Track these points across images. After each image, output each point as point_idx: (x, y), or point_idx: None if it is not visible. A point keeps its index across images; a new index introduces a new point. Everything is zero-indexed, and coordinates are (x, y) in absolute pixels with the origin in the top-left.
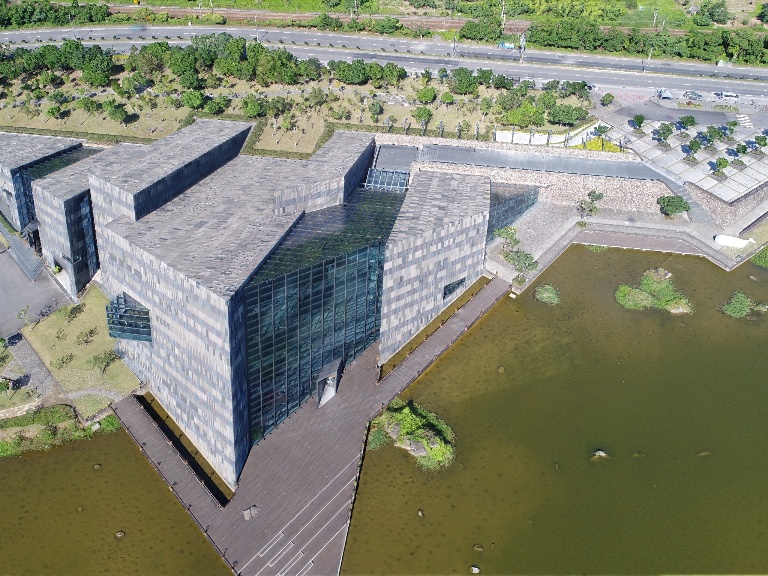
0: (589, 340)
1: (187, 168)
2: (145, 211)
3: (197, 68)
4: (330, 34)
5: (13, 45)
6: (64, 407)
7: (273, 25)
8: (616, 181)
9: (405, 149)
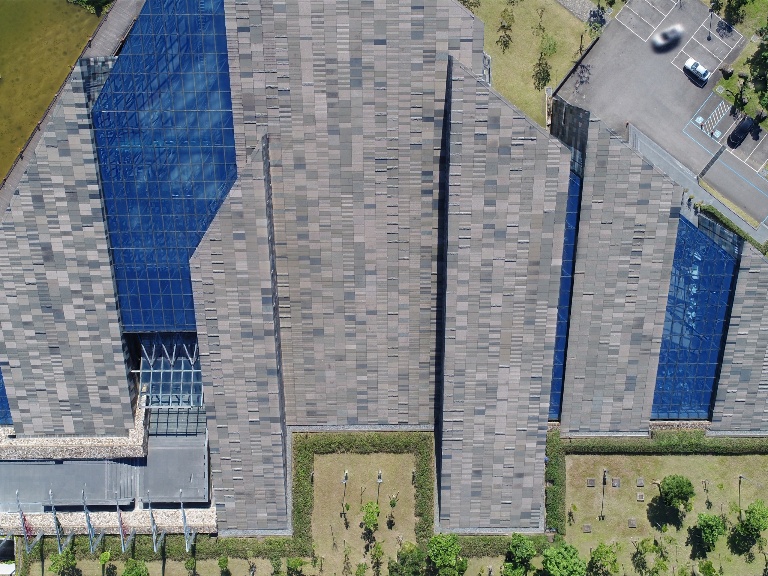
0: None
1: None
2: None
3: None
4: None
5: None
6: None
7: None
8: None
9: (165, 498)
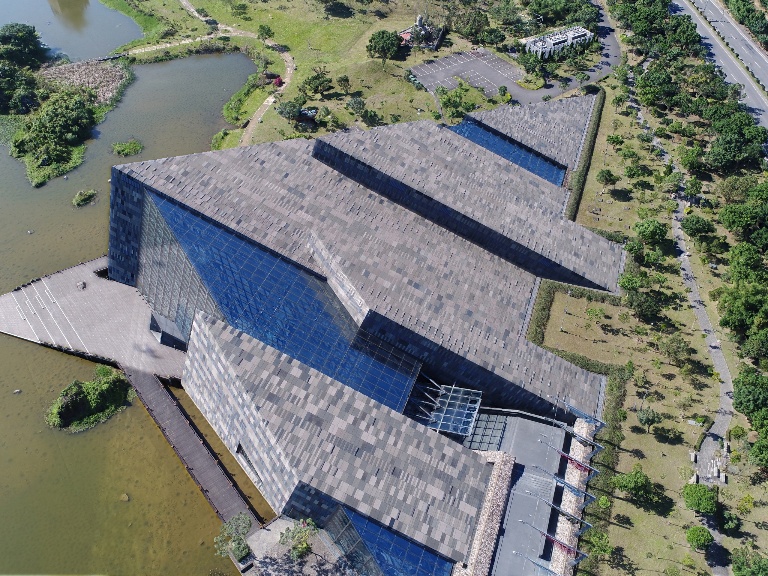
0: None
1: (422, 196)
2: (330, 162)
3: None
4: None
5: None
6: None
7: None
8: None
9: None
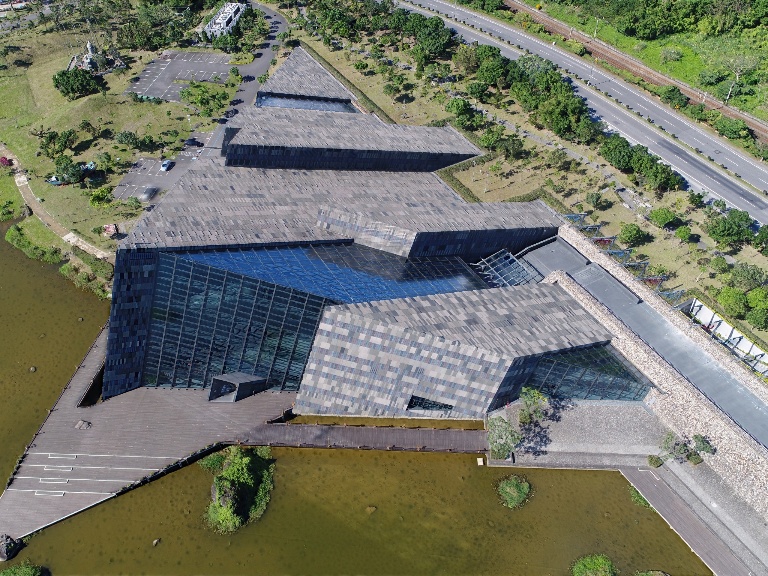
0: (484, 568)
1: (332, 152)
2: (244, 163)
3: (497, 82)
4: (667, 109)
5: (412, 5)
6: (111, 268)
7: (622, 76)
8: (752, 449)
9: (576, 256)
